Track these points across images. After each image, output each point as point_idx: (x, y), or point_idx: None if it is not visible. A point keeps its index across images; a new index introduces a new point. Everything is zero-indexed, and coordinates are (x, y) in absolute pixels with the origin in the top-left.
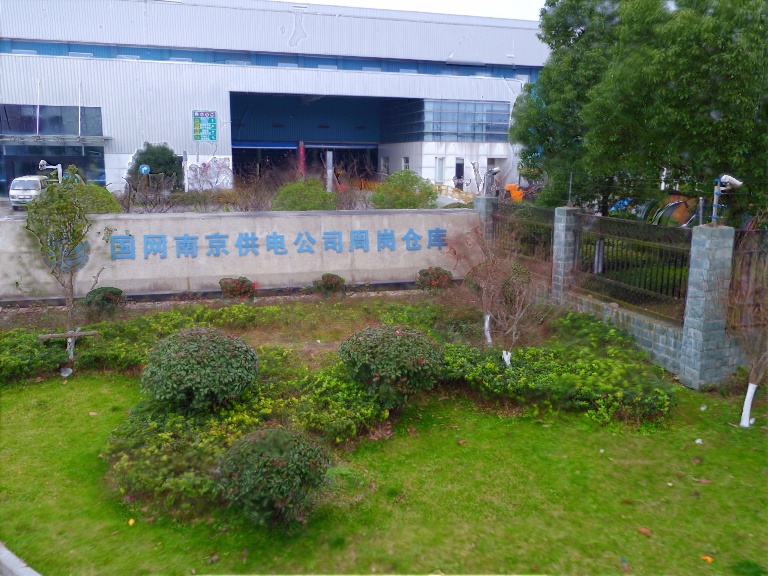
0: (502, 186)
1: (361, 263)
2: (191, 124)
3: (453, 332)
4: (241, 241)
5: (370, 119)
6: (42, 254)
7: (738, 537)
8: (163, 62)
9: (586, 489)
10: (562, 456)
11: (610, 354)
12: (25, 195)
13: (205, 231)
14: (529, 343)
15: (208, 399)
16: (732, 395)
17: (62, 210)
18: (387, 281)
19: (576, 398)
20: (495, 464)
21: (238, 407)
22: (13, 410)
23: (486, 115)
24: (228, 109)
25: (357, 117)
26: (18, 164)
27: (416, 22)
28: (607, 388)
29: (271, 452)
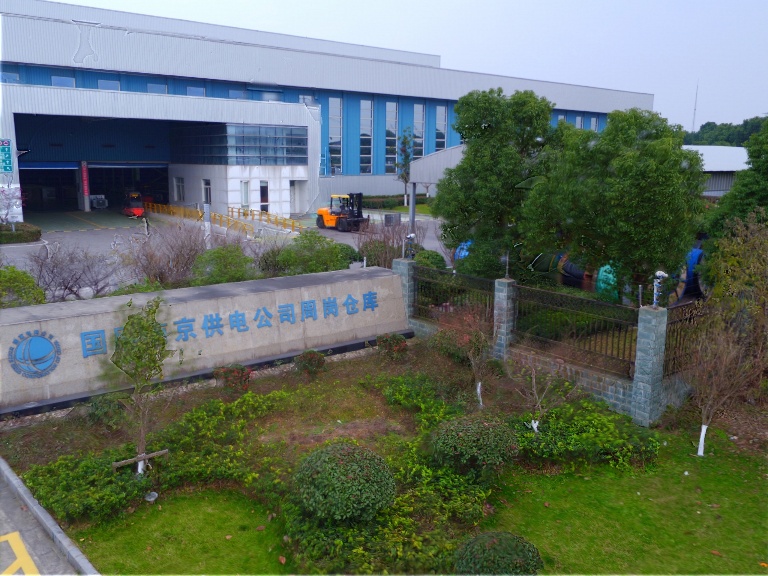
0: (313, 210)
1: (311, 331)
2: None
3: (462, 402)
4: (207, 323)
5: (159, 138)
6: (9, 361)
7: (765, 545)
8: None
9: (657, 528)
10: (619, 503)
11: (587, 408)
12: None
13: (173, 317)
14: None
15: None
16: (674, 429)
17: (155, 343)
18: (335, 345)
19: (600, 453)
20: (587, 520)
21: None
22: (148, 549)
23: (286, 139)
24: (12, 132)
25: (145, 136)
26: None
27: (202, 40)
28: (619, 442)
29: (513, 555)
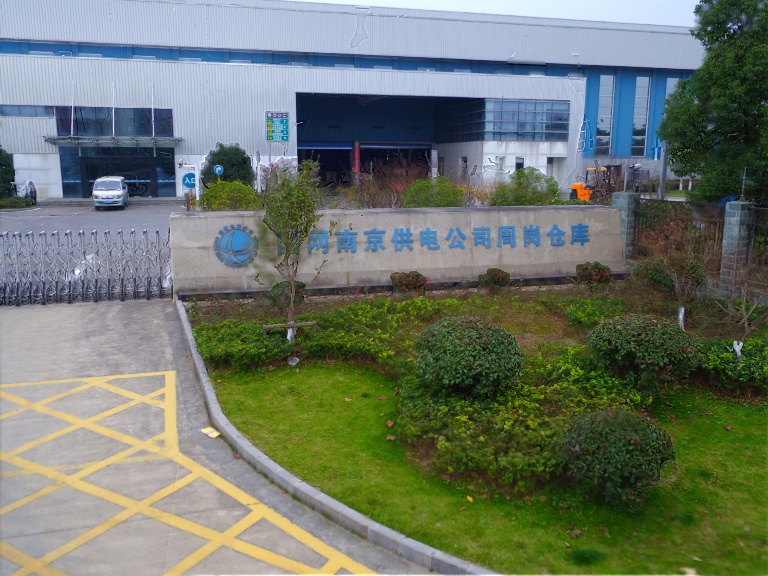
0: (567, 185)
1: (508, 258)
2: (258, 125)
3: None
4: (397, 237)
5: (424, 119)
6: (215, 249)
7: None
8: (232, 64)
9: None
10: None
11: None
12: (108, 195)
13: (363, 227)
14: (733, 335)
15: (491, 384)
16: None
17: (300, 204)
18: (534, 276)
19: None
20: None
21: (509, 393)
22: (270, 396)
23: (546, 114)
24: (294, 110)
25: (411, 117)
26: (92, 165)
27: (471, 22)
28: None
29: (629, 431)
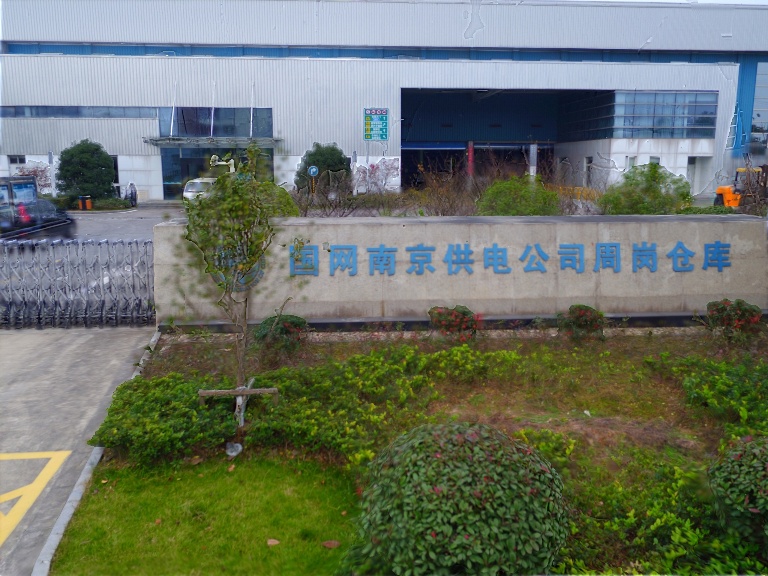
0: (711, 188)
1: (609, 288)
2: (360, 124)
3: None
4: (451, 255)
5: (547, 116)
6: None
7: None
8: (335, 59)
9: None
10: None
11: None
12: None
13: (406, 241)
14: None
15: None
16: None
17: (236, 212)
18: (645, 313)
19: None
20: None
21: None
22: (156, 522)
23: (688, 107)
24: (399, 107)
25: (532, 114)
26: (193, 167)
27: (603, 7)
28: None
29: None
